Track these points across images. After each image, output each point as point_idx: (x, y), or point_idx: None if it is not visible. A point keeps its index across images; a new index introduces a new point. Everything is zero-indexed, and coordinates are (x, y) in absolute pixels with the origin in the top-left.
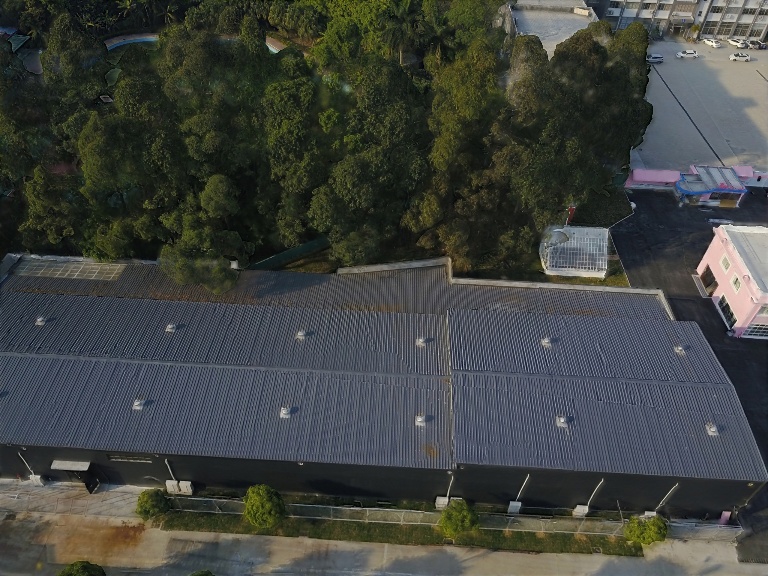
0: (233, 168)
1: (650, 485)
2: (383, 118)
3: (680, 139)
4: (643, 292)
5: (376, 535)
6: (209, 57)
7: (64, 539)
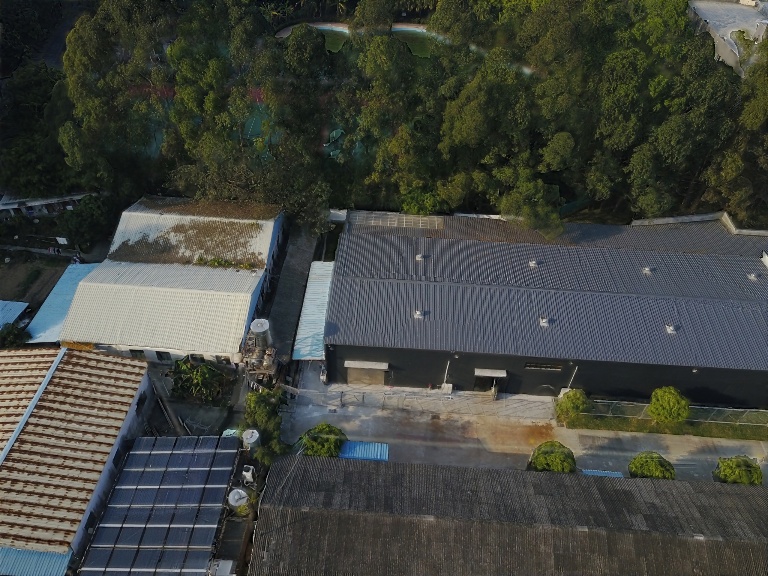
0: (567, 128)
1: None
2: (704, 84)
3: None
4: None
5: (749, 434)
6: (575, 28)
7: (490, 434)
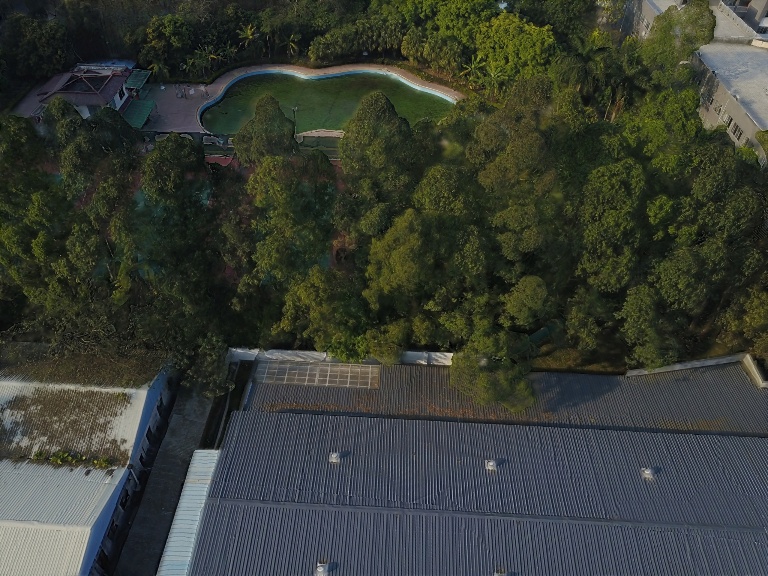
0: (538, 264)
1: None
2: (722, 207)
3: None
4: None
5: None
6: (544, 142)
7: None
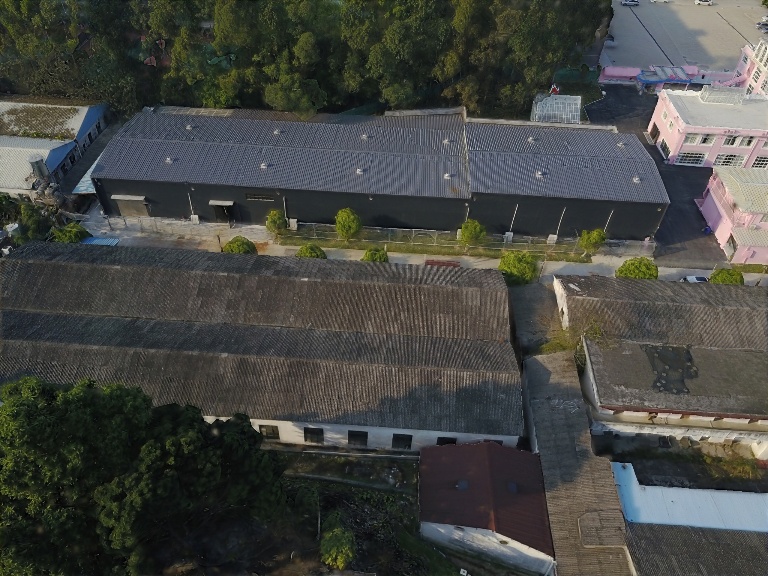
0: (316, 31)
1: (596, 213)
2: None
3: (646, 56)
4: (603, 128)
5: (418, 250)
6: None
7: (218, 247)
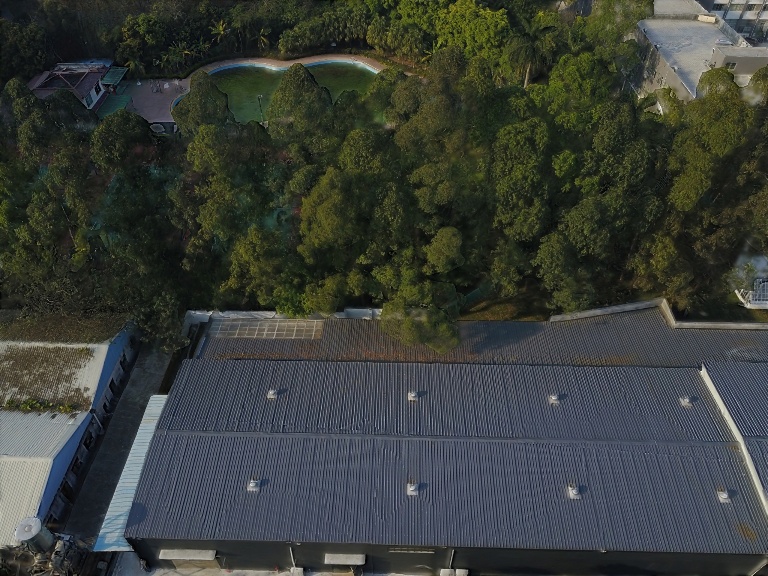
0: (457, 218)
1: None
2: (621, 158)
3: None
4: None
5: None
6: (449, 103)
7: None
